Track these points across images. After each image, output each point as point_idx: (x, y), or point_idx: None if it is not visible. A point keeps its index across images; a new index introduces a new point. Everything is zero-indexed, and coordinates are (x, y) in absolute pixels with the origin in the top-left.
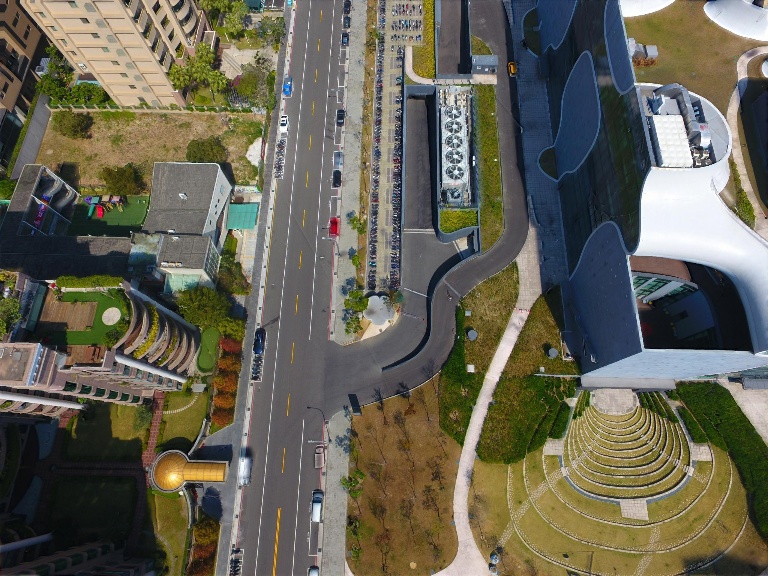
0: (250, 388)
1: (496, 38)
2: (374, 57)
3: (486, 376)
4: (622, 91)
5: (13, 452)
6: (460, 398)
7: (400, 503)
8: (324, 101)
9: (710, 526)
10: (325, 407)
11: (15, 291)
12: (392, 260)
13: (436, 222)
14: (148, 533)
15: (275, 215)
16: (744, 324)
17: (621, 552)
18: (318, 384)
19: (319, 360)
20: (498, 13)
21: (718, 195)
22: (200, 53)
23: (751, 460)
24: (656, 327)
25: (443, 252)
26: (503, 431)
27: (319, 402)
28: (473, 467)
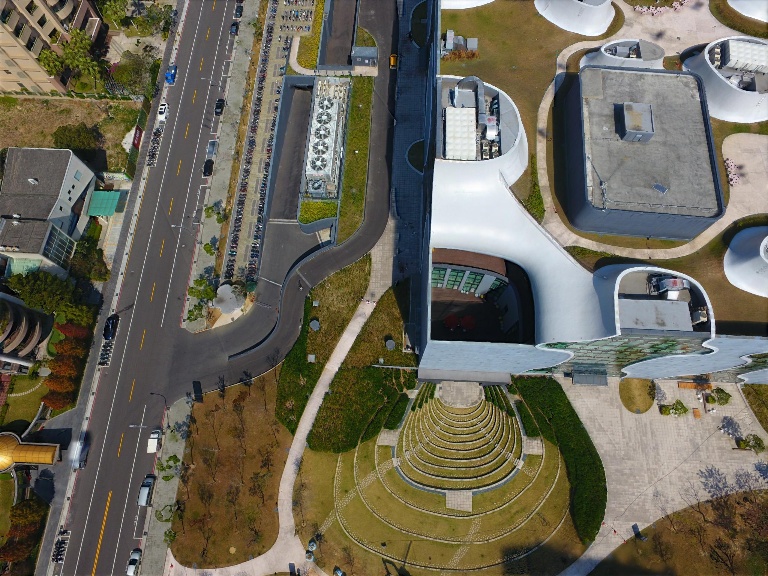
0: (97, 373)
1: (383, 30)
2: (260, 47)
3: (326, 366)
4: (434, 83)
5: None
6: (297, 387)
7: (227, 489)
8: (206, 90)
9: (531, 519)
10: (168, 393)
11: None
12: (252, 250)
13: None
14: None
15: (143, 203)
16: (532, 318)
17: (439, 542)
18: (164, 371)
19: (168, 347)
20: (388, 5)
21: (508, 188)
22: (74, 39)
23: (576, 455)
24: (484, 321)
25: (305, 243)
26: (336, 421)
27: (163, 388)
28: (302, 455)
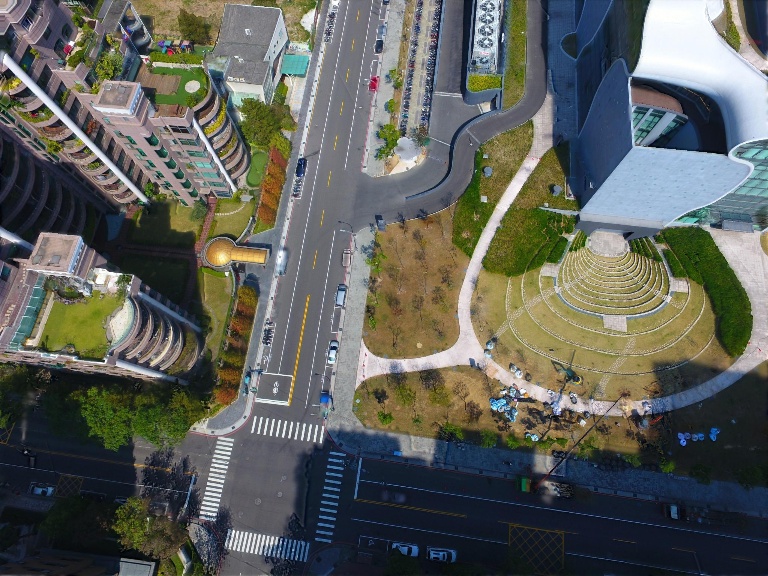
0: (290, 203)
1: None
2: None
3: (497, 206)
4: None
5: (90, 223)
6: (472, 221)
7: (413, 298)
8: None
9: (680, 340)
10: (354, 223)
11: (119, 52)
12: (422, 114)
13: (464, 87)
14: (197, 302)
15: (322, 71)
16: (722, 134)
17: (600, 352)
18: (349, 205)
19: (352, 186)
20: None
21: (711, 22)
22: None
23: (722, 290)
24: None
25: (468, 112)
26: (507, 250)
27: (349, 218)
28: (478, 275)
